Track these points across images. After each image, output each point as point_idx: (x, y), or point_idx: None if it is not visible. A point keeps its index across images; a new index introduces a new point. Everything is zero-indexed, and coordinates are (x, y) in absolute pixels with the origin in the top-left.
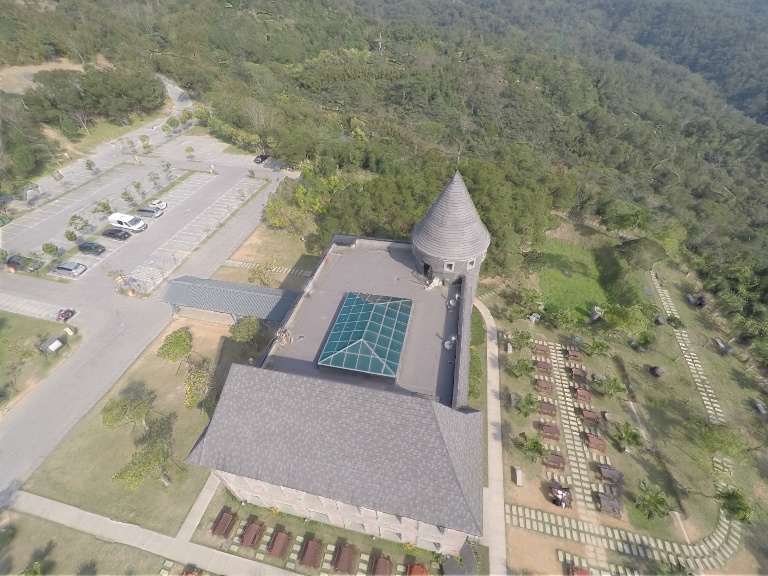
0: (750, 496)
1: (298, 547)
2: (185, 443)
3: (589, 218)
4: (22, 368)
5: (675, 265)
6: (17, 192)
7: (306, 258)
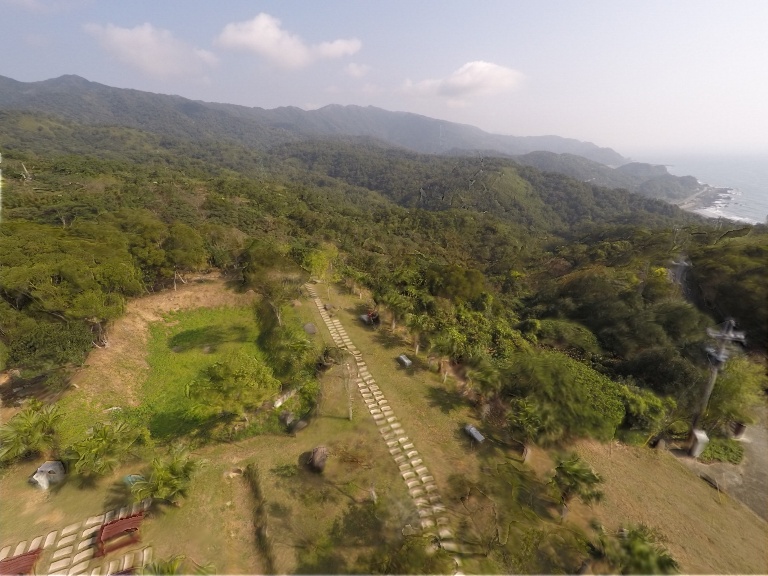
0: None
1: None
2: None
3: None
4: None
5: (348, 291)
6: None
7: None
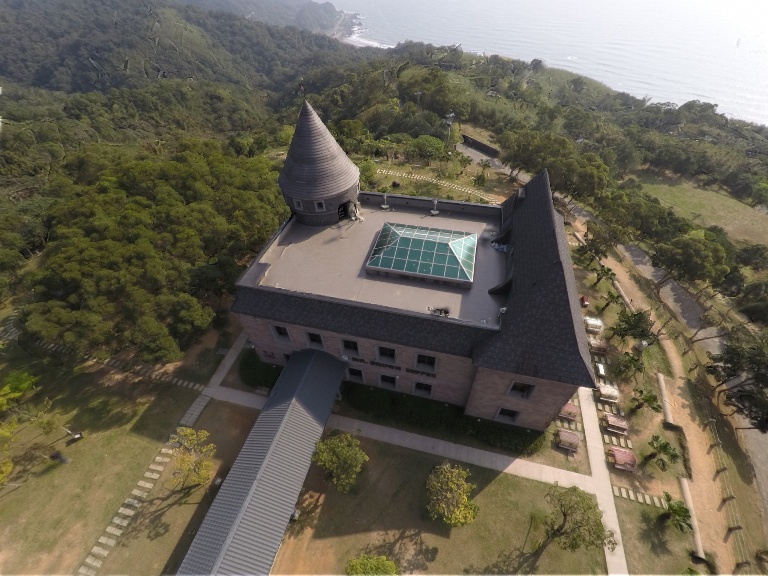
0: None
1: None
2: (500, 533)
3: None
4: None
5: None
6: None
7: (142, 426)
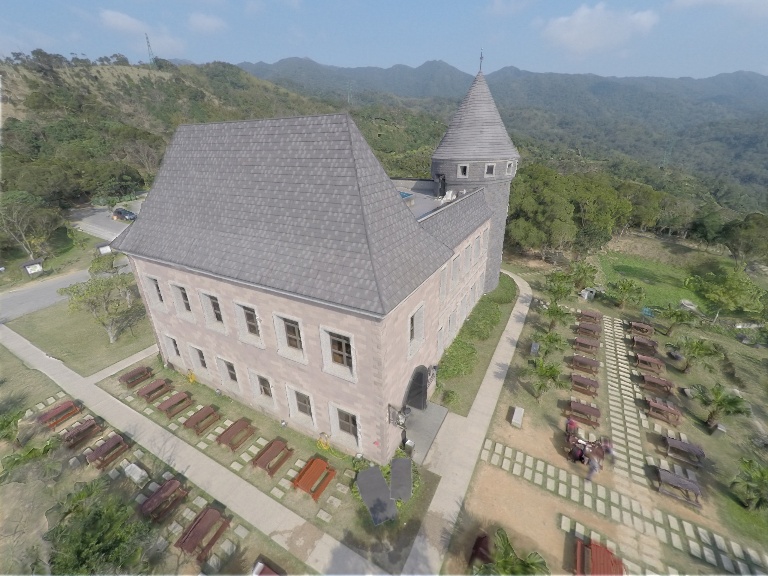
0: None
1: (193, 413)
2: None
3: (684, 241)
4: (74, 263)
5: None
6: (149, 180)
7: None
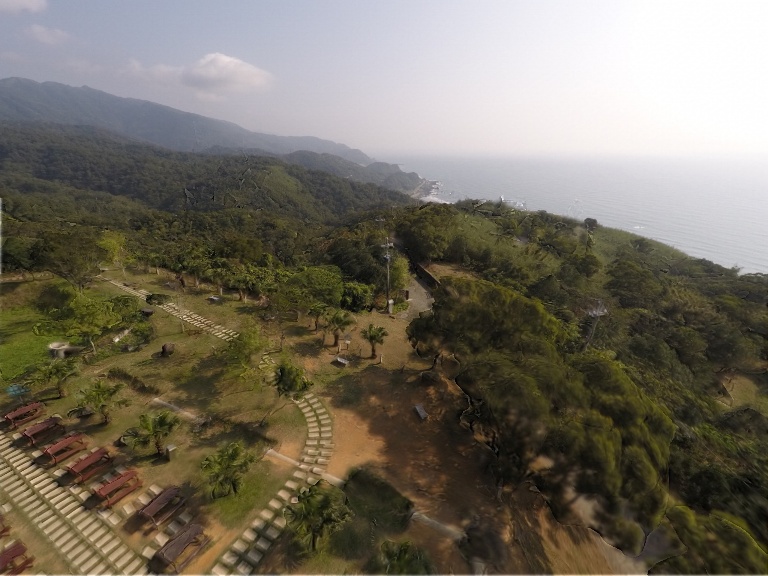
0: (308, 375)
1: None
2: None
3: (3, 277)
4: None
5: (142, 272)
6: None
7: None
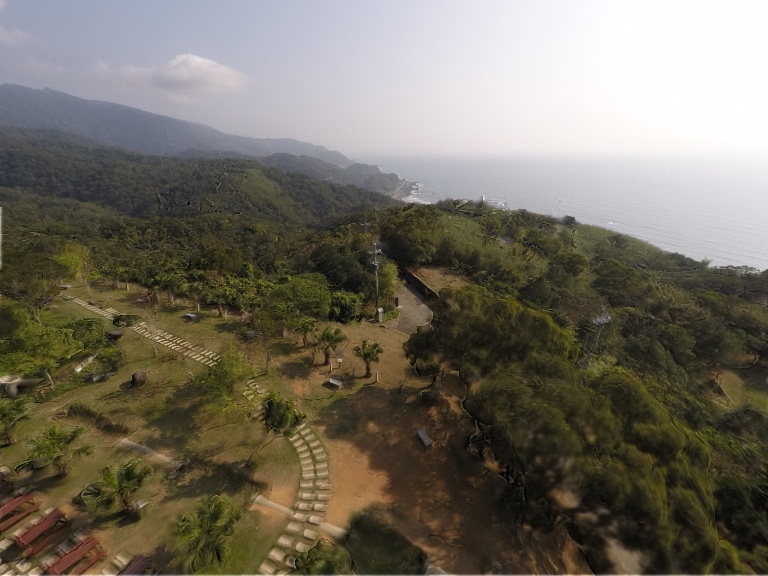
0: (298, 400)
1: None
2: None
3: None
4: None
5: (110, 288)
6: None
7: None
